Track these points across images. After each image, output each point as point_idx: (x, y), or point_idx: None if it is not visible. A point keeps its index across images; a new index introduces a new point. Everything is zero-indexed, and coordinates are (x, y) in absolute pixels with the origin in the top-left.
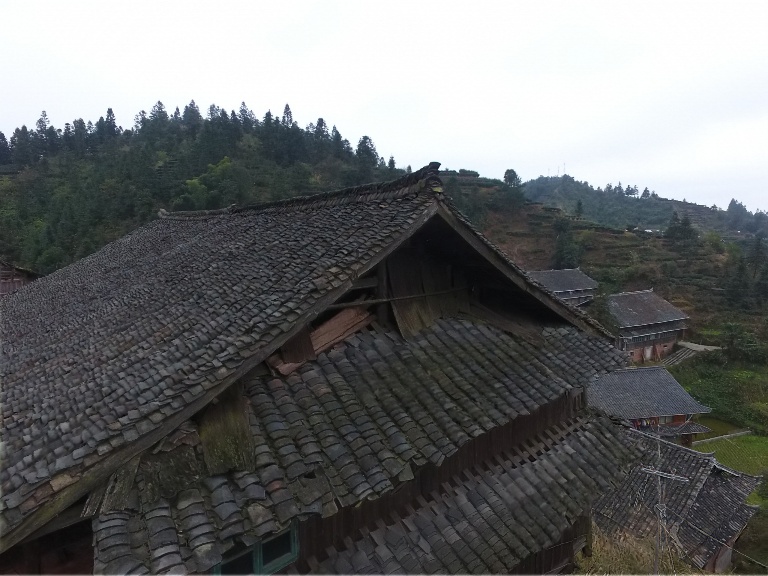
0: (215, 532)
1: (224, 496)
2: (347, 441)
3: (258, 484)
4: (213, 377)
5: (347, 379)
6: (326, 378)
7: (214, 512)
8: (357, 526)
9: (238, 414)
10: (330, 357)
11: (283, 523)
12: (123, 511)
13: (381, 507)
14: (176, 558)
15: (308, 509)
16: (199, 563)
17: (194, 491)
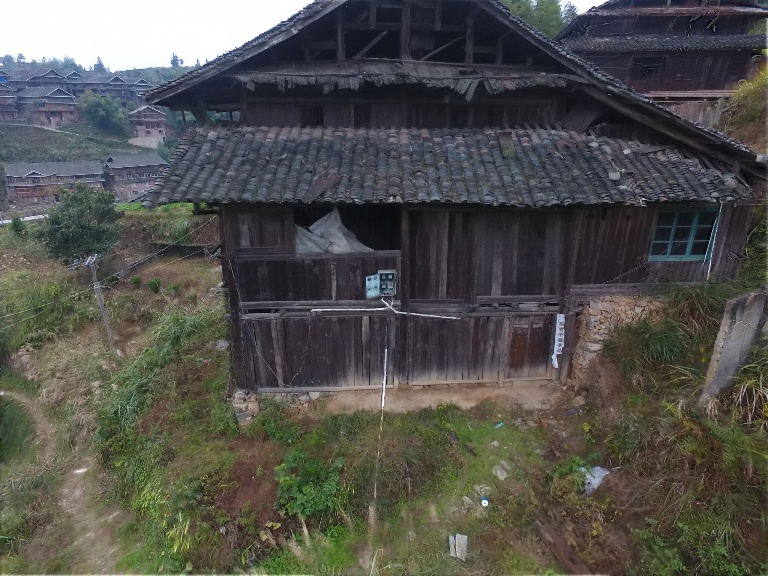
0: None
1: None
2: None
3: None
4: None
5: None
6: None
7: None
8: None
9: None
10: None
11: None
12: None
13: None
14: None
15: None
16: None
17: None
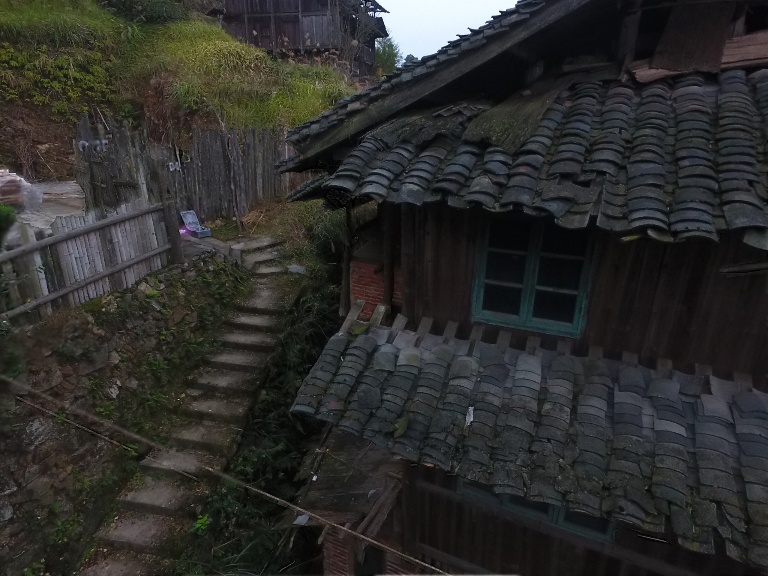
0: (431, 183)
1: (461, 160)
2: (678, 166)
3: (506, 165)
4: (499, 24)
5: (761, 104)
6: (716, 98)
7: (444, 169)
8: (695, 358)
9: (537, 103)
10: (752, 77)
11: (502, 205)
12: (378, 140)
13: (761, 362)
14: (384, 181)
15: (541, 204)
16: (399, 195)
17: (442, 150)
